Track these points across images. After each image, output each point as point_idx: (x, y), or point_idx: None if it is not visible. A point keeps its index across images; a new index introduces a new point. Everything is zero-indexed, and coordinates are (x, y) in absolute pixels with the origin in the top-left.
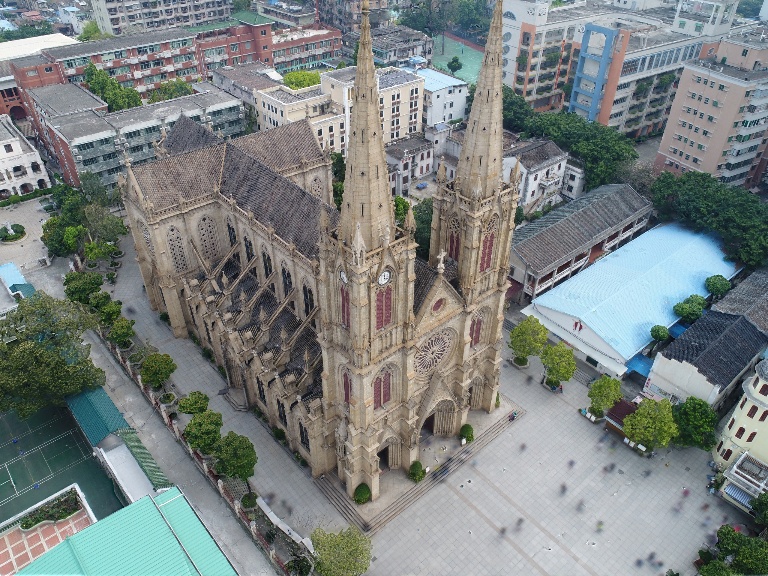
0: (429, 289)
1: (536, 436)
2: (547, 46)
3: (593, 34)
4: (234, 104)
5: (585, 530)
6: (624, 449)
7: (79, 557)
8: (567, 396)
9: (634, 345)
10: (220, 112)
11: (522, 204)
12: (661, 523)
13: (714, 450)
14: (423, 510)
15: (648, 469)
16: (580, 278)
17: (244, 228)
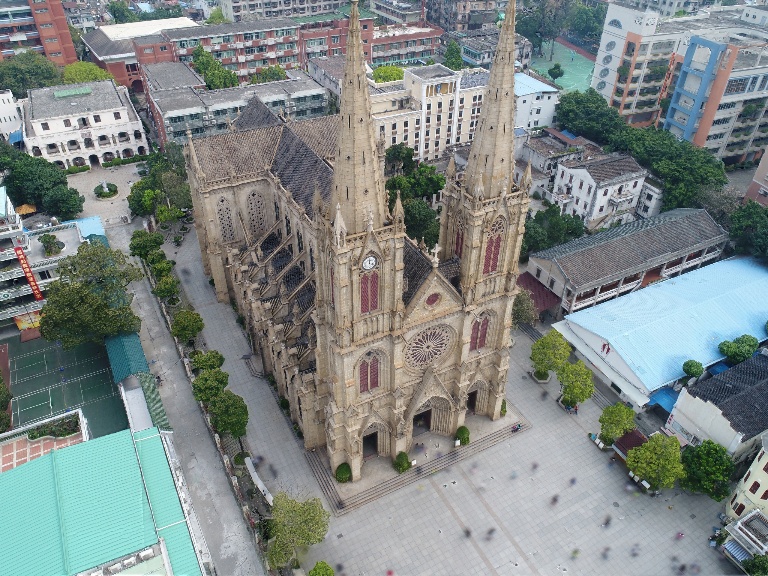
0: (423, 282)
1: (536, 452)
2: (653, 58)
3: (699, 48)
4: (318, 92)
5: (559, 554)
6: (627, 482)
7: (56, 469)
8: (581, 418)
9: (662, 377)
10: (304, 99)
11: (588, 219)
12: (645, 565)
13: (728, 502)
14: (400, 500)
15: (648, 508)
16: (624, 300)
17: (285, 206)
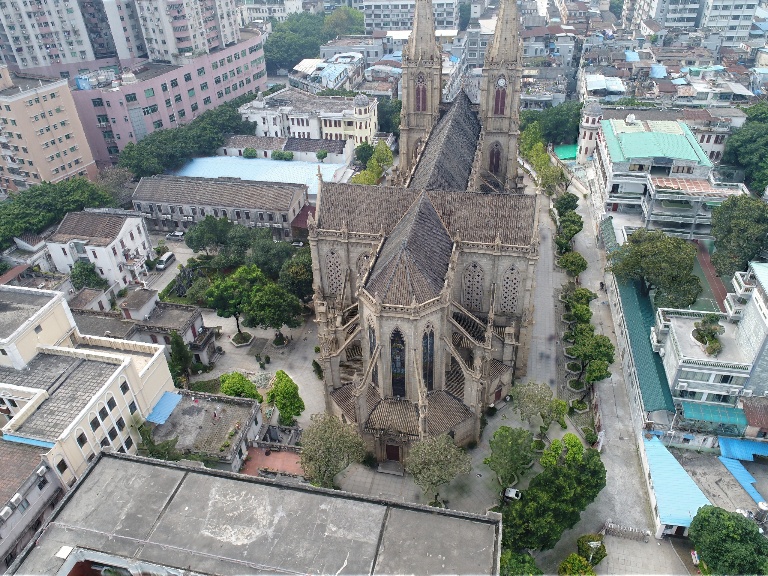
0: None
1: None
2: None
3: None
4: None
5: None
6: None
7: None
8: None
9: None
10: None
11: (152, 251)
12: None
13: None
14: None
15: None
16: None
17: None
